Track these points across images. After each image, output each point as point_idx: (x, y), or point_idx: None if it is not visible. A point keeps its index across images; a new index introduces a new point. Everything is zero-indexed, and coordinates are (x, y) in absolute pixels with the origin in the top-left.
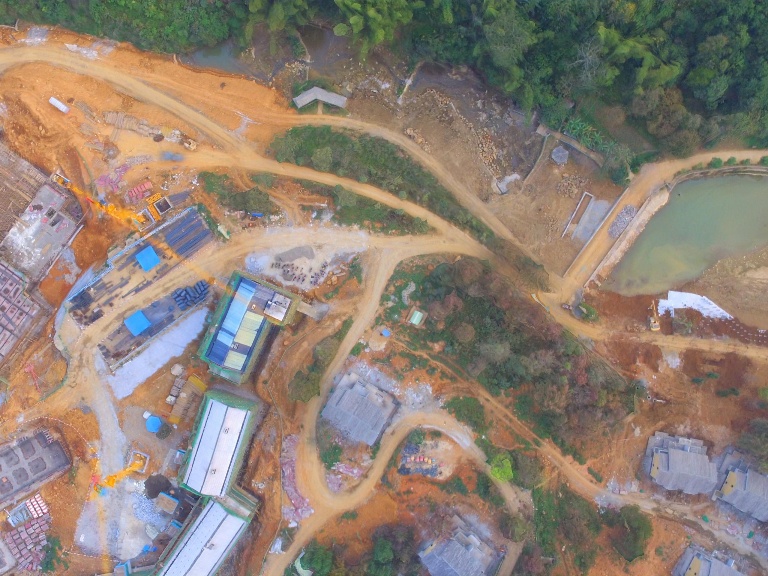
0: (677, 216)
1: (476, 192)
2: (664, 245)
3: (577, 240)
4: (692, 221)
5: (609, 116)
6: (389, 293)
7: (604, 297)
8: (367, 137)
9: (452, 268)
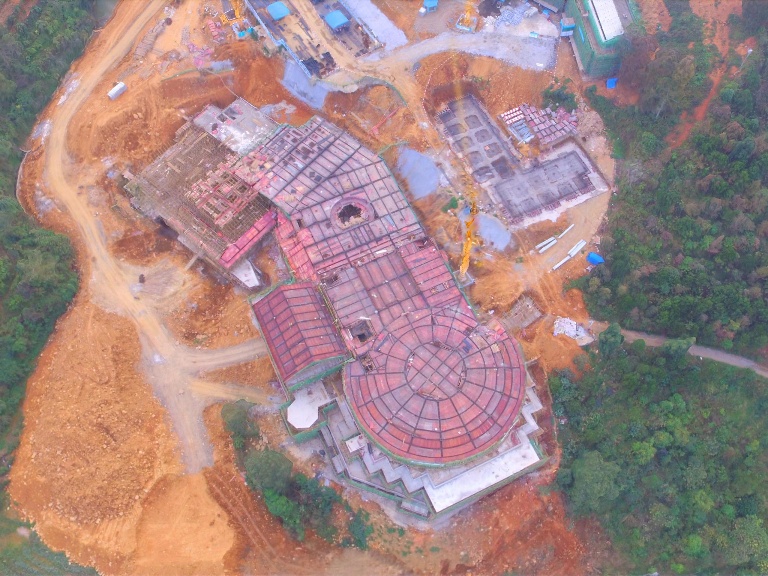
0: None
1: None
2: None
3: None
4: None
5: None
6: None
7: None
8: None
9: None
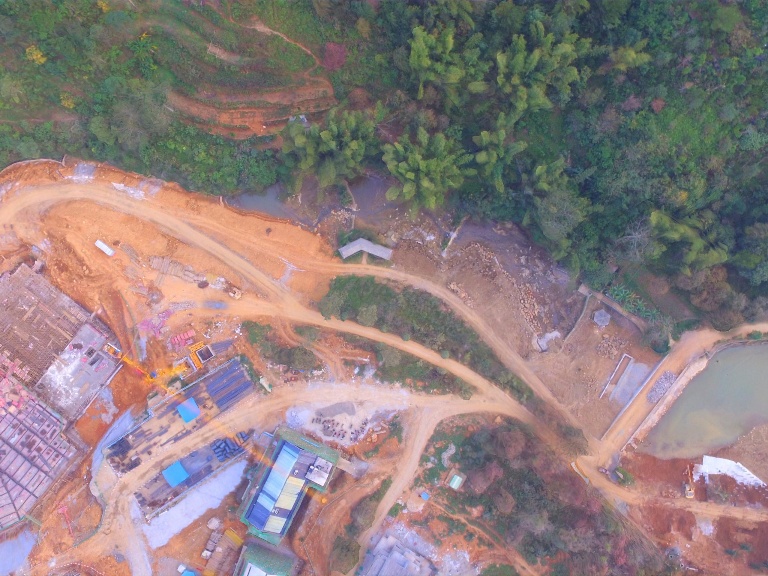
0: (714, 381)
1: (517, 349)
2: (701, 410)
3: (615, 402)
4: (729, 387)
5: (653, 286)
6: (429, 454)
7: (640, 460)
8: (410, 289)
9: (494, 435)
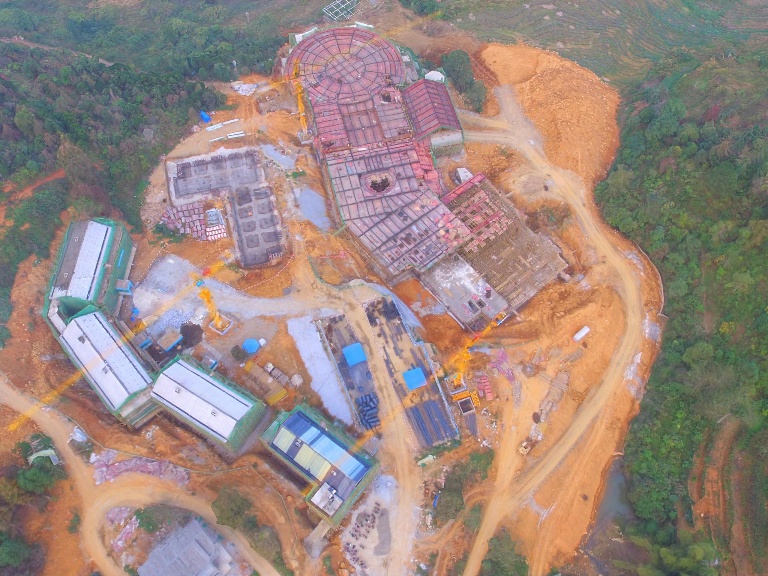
0: None
1: None
2: None
3: None
4: None
5: None
6: None
7: None
8: None
9: None
